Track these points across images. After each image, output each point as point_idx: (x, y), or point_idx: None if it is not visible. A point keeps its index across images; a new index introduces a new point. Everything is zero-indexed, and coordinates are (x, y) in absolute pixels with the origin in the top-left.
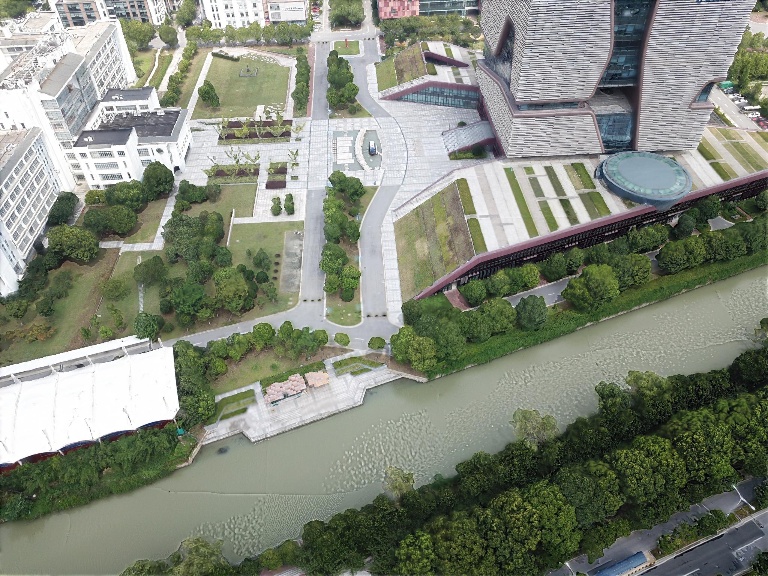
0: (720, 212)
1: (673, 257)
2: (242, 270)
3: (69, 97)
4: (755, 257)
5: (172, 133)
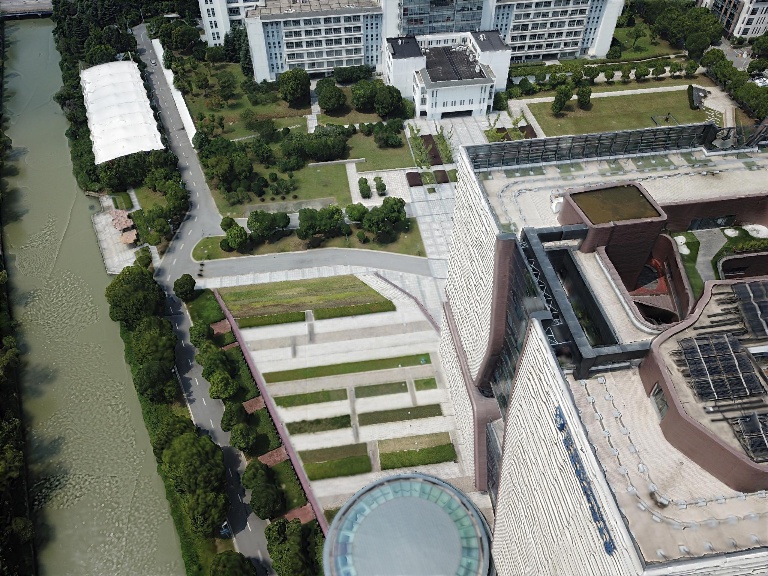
0: None
1: None
2: (269, 177)
3: (428, 5)
4: None
5: (437, 82)
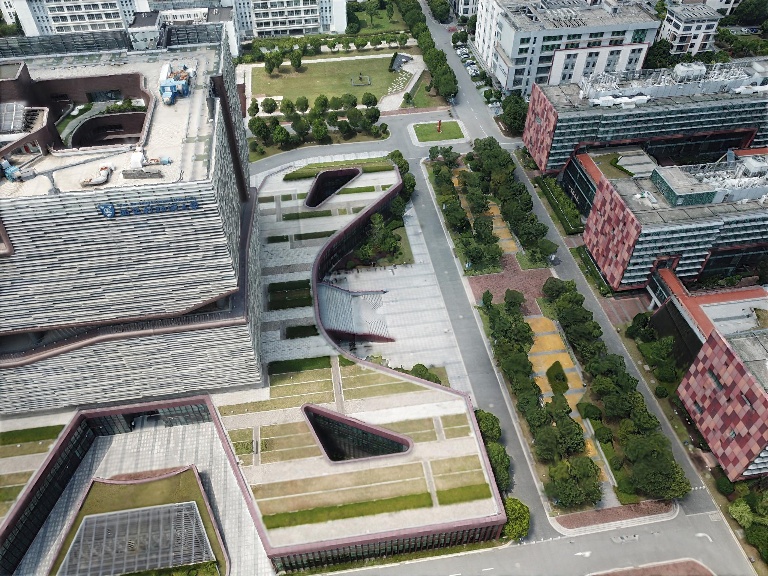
0: None
1: None
2: None
3: None
4: None
5: None
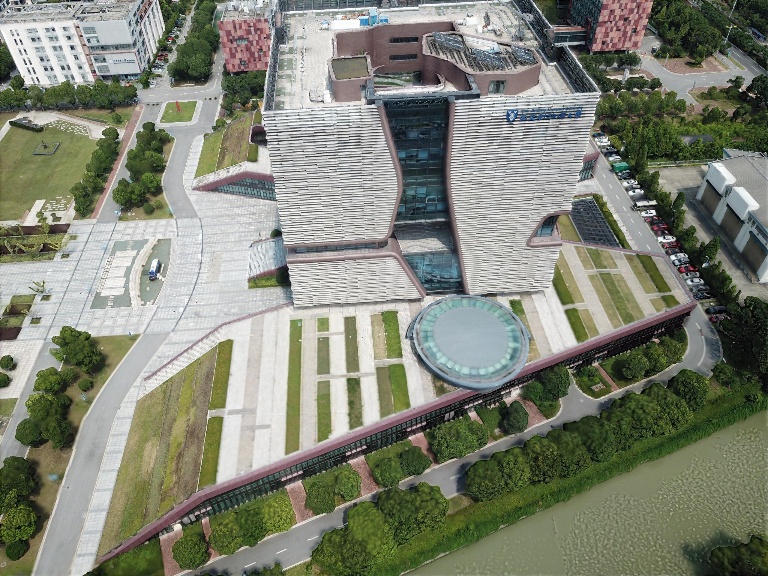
0: (577, 379)
1: (481, 487)
2: None
3: None
4: (610, 464)
5: None
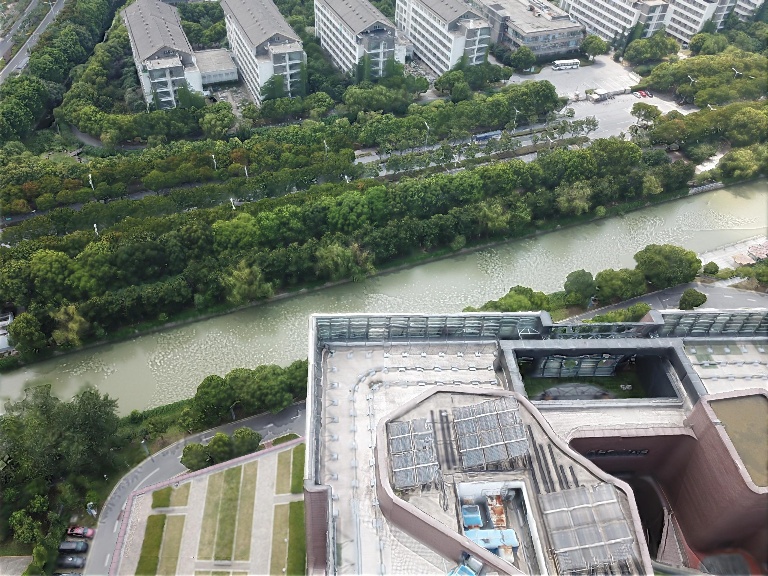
0: None
1: None
2: None
3: None
4: None
5: None
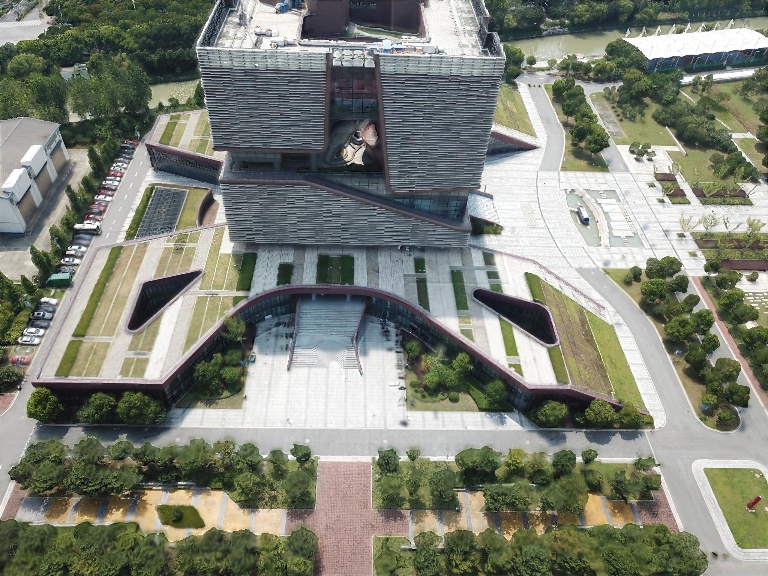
0: None
1: None
2: None
3: None
4: None
5: None
